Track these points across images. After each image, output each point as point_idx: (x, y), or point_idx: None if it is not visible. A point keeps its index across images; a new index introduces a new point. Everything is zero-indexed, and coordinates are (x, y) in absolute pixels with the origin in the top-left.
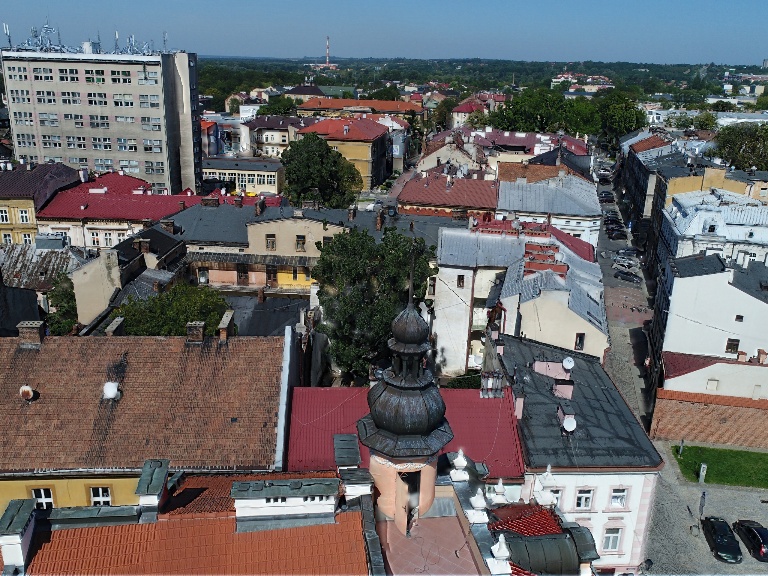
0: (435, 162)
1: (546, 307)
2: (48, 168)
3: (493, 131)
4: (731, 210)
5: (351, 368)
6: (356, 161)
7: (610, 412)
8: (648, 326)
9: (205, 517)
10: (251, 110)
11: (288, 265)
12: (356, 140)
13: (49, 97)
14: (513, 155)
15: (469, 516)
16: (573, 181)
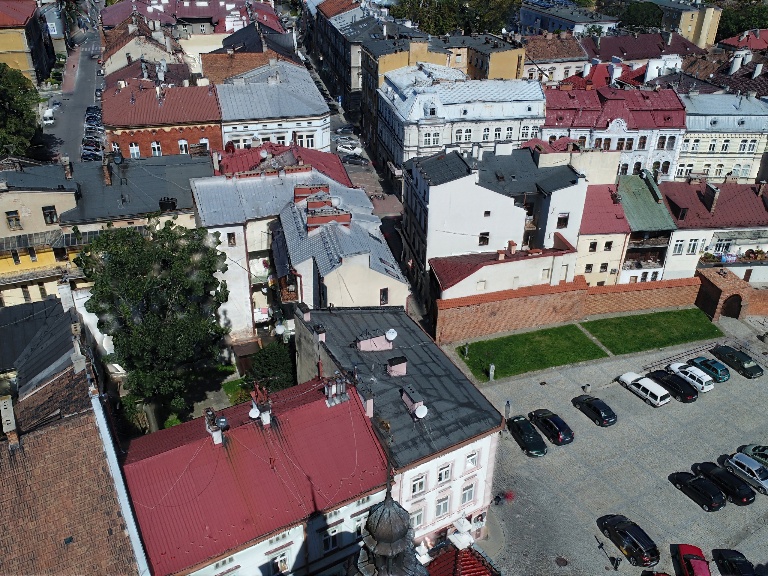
0: (125, 60)
1: (349, 273)
2: None
3: (170, 2)
4: (443, 89)
5: (155, 390)
6: (9, 53)
7: (441, 375)
8: (399, 223)
9: None
10: None
11: (5, 250)
12: (2, 27)
13: None
14: (206, 35)
15: None
16: (286, 70)
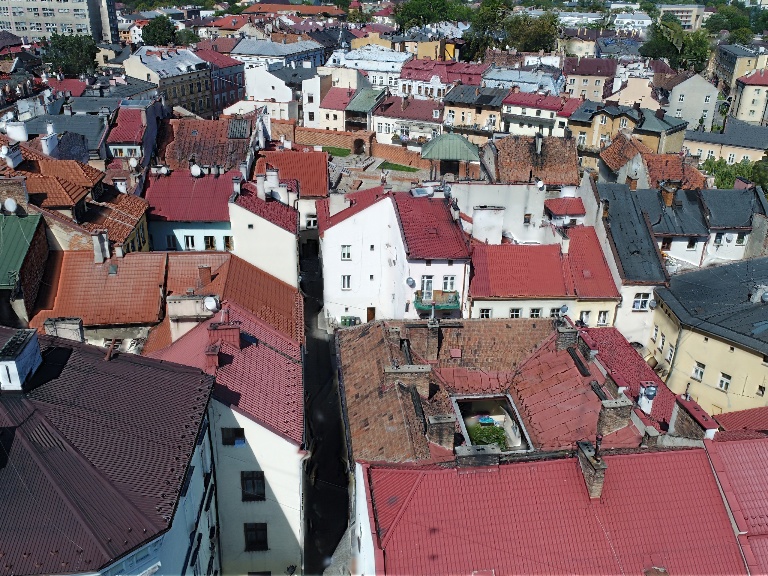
0: None
1: (133, 62)
2: None
3: (334, 22)
4: (355, 52)
5: None
6: None
7: (129, 90)
8: None
9: None
10: (209, 15)
11: None
12: None
13: None
14: None
15: None
16: (302, 42)
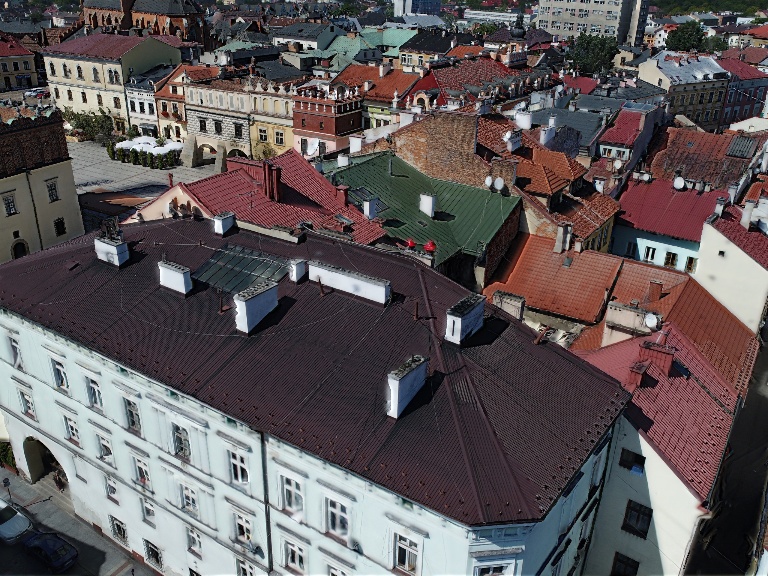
0: None
1: (649, 66)
2: (536, 31)
3: None
4: None
5: None
6: None
7: (636, 93)
8: None
9: (480, 47)
10: (746, 21)
11: None
12: None
13: None
14: None
15: None
16: None
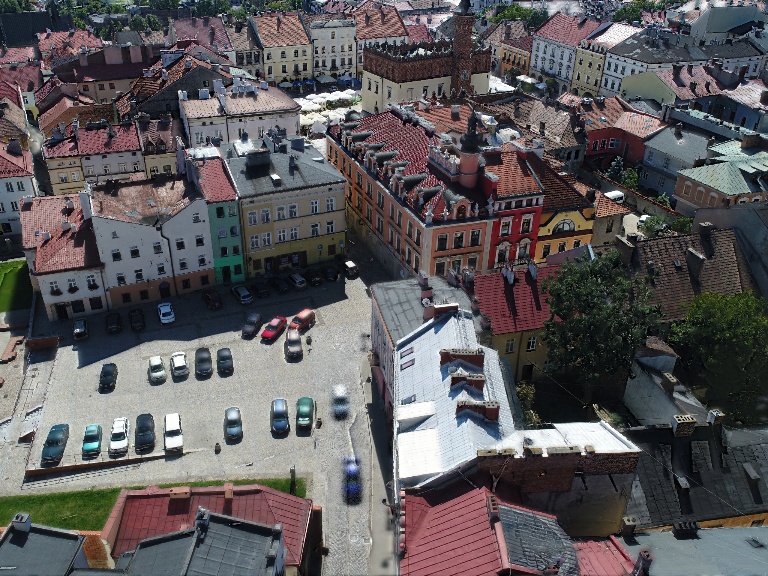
0: None
1: None
2: None
3: None
4: None
5: None
6: None
7: (397, 305)
8: None
9: None
10: None
11: None
12: None
13: None
14: None
15: (448, 156)
16: None
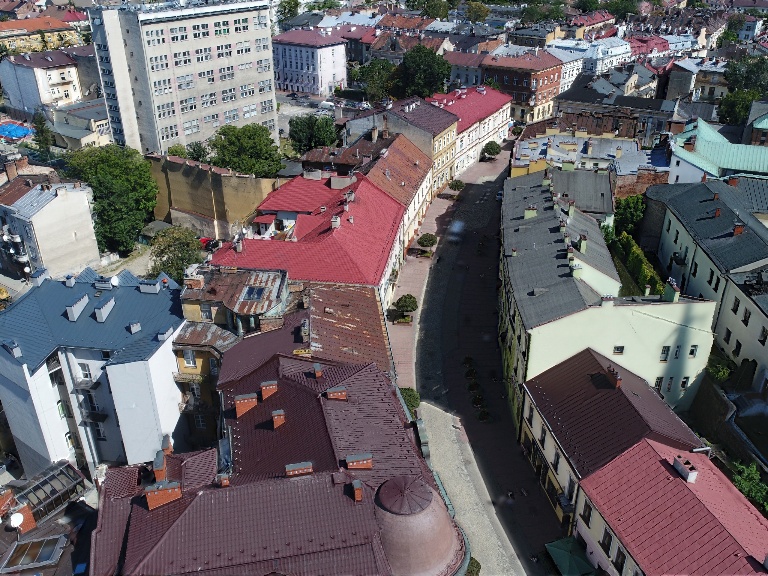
0: (442, 52)
1: None
2: None
3: None
4: None
5: None
6: None
7: None
8: None
9: None
10: None
11: None
12: None
13: (185, 58)
14: None
15: None
16: None
